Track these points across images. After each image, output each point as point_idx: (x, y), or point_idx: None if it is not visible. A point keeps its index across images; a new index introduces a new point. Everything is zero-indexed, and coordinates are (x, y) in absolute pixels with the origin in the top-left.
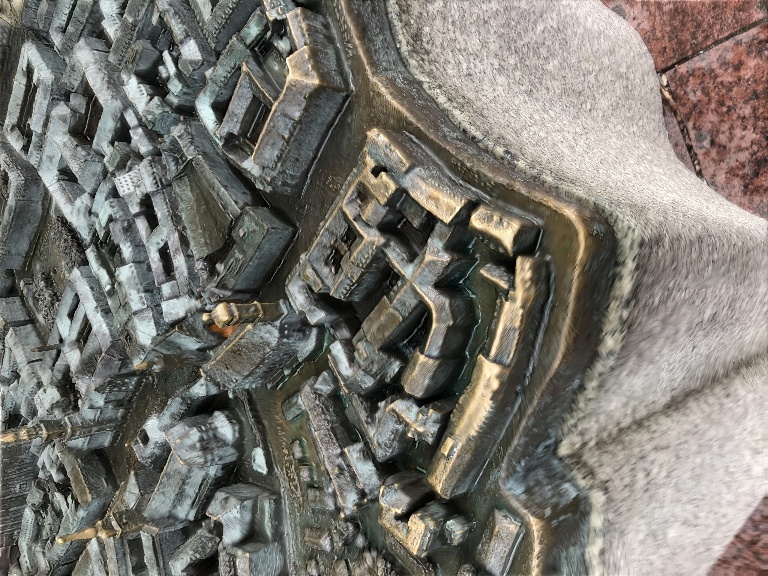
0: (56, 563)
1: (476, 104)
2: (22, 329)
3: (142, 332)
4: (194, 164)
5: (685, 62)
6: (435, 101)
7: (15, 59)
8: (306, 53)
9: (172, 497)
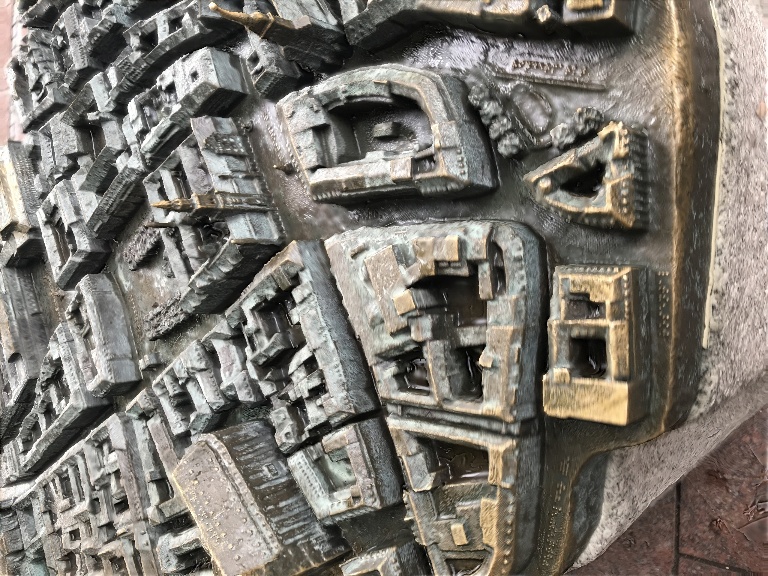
0: (351, 406)
1: None
2: None
3: None
4: None
5: None
6: None
7: (49, 306)
8: None
9: (296, 8)
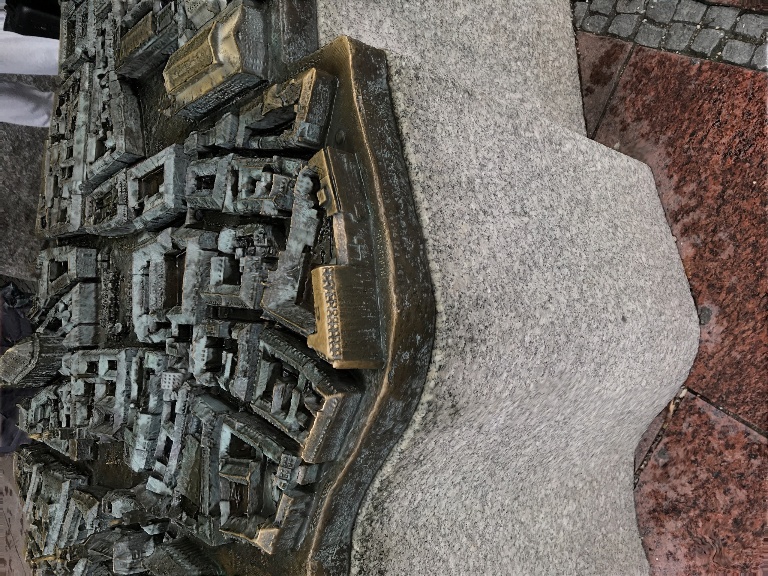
0: None
1: (390, 556)
2: (86, 287)
3: (135, 461)
4: (203, 451)
5: (705, 401)
6: (350, 568)
7: None
8: (274, 534)
9: None
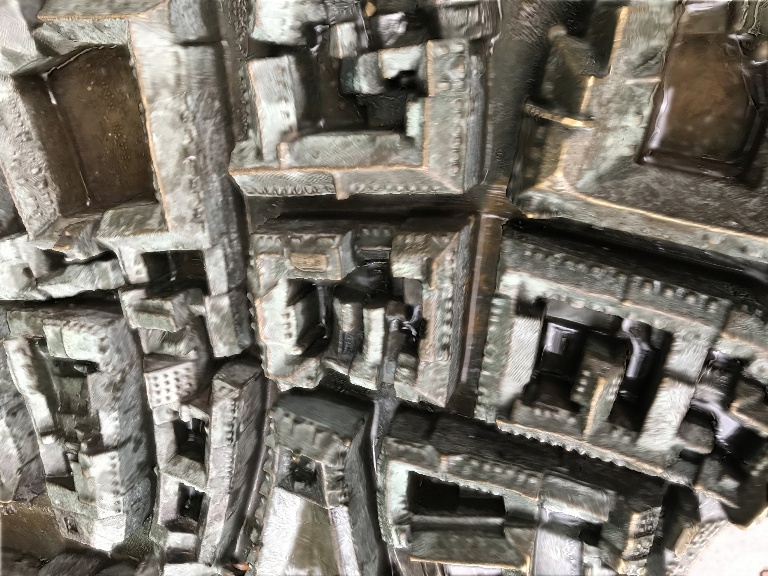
0: None
1: None
2: None
3: (102, 537)
4: (331, 514)
5: None
6: None
7: None
8: None
9: None
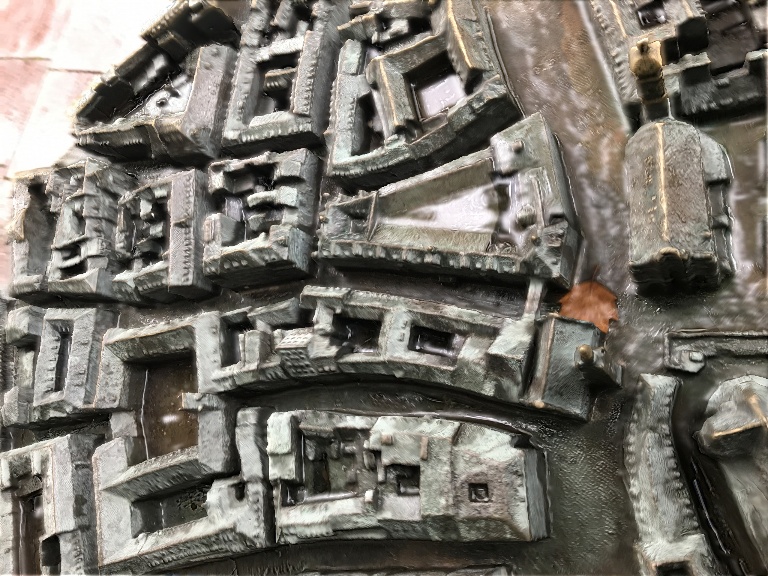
0: None
1: None
2: None
3: (490, 451)
4: (385, 194)
5: None
6: None
7: None
8: None
9: None
